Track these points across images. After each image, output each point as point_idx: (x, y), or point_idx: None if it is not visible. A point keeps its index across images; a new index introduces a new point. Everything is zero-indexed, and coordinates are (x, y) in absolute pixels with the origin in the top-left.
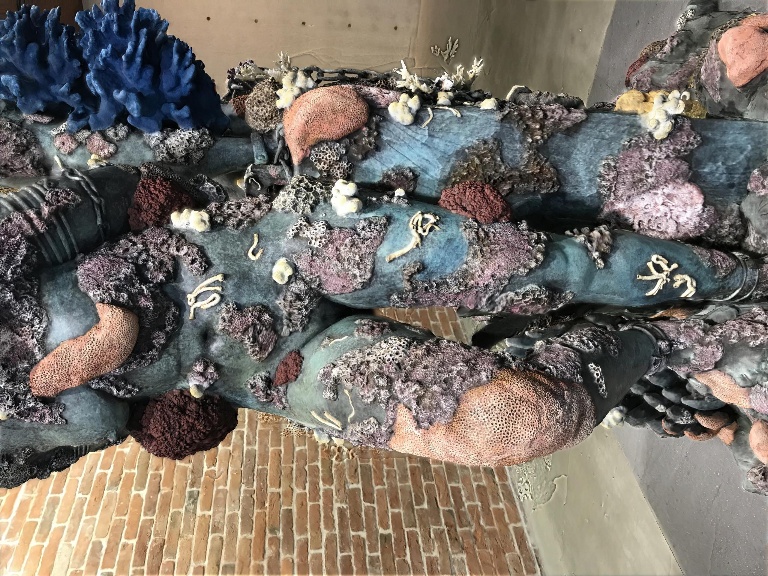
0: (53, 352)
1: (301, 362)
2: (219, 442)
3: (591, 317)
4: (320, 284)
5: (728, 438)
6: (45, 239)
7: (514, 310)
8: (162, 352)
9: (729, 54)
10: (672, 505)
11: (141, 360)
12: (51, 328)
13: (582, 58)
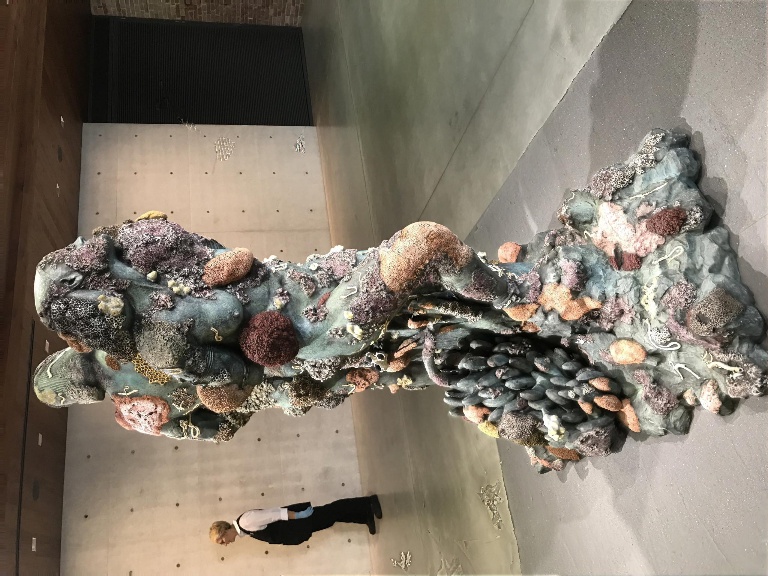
0: (218, 255)
1: (330, 292)
2: (290, 350)
3: (496, 348)
4: (333, 272)
5: (632, 412)
6: (210, 244)
7: (431, 278)
8: (261, 283)
9: (502, 253)
10: (683, 566)
11: (252, 282)
12: (216, 251)
13: (486, 438)
